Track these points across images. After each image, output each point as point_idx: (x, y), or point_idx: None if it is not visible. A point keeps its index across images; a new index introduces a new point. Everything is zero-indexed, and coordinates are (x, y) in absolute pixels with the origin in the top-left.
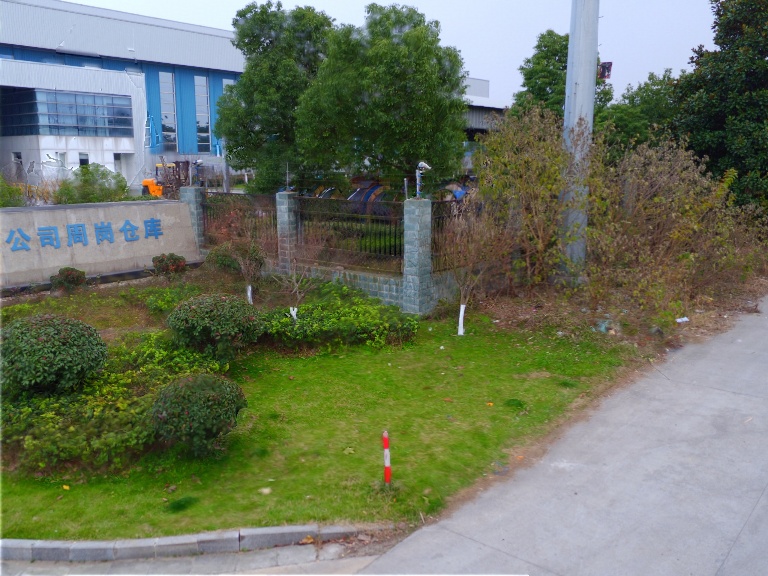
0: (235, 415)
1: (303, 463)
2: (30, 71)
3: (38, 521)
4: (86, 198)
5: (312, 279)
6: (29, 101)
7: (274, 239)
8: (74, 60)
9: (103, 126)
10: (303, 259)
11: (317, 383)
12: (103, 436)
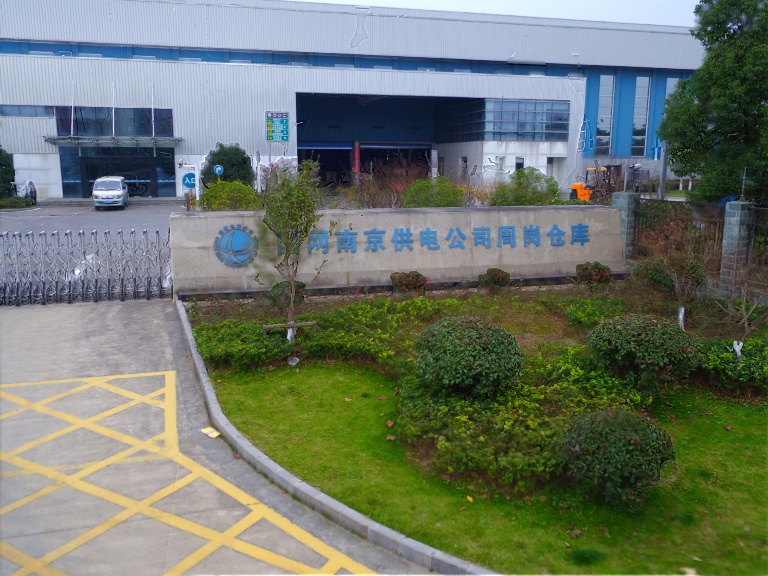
0: (659, 467)
1: (742, 549)
2: (483, 83)
3: (441, 529)
4: (519, 201)
5: (762, 307)
6: (479, 110)
7: (717, 255)
8: (522, 69)
9: (540, 131)
10: (752, 282)
11: (764, 442)
12: (511, 454)
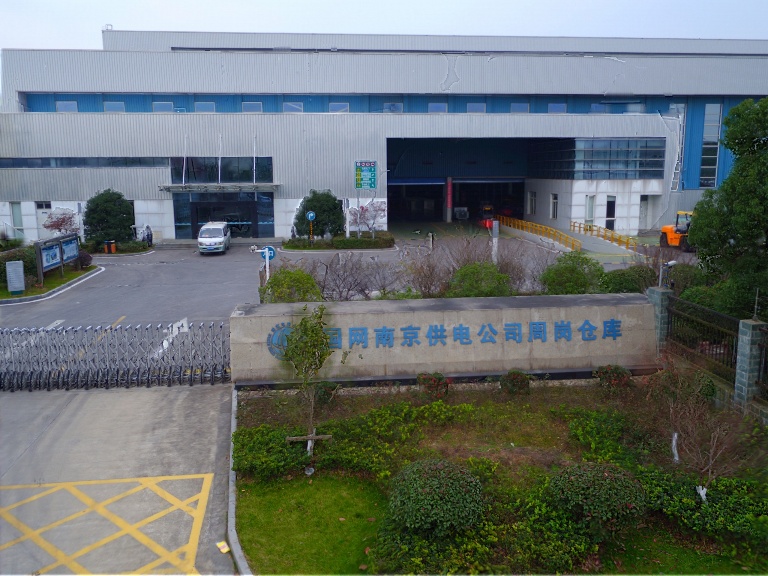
0: None
1: None
2: (573, 122)
3: None
4: (563, 286)
5: (767, 429)
6: (569, 149)
7: (733, 368)
8: (614, 108)
9: (634, 169)
10: (763, 401)
11: None
12: None
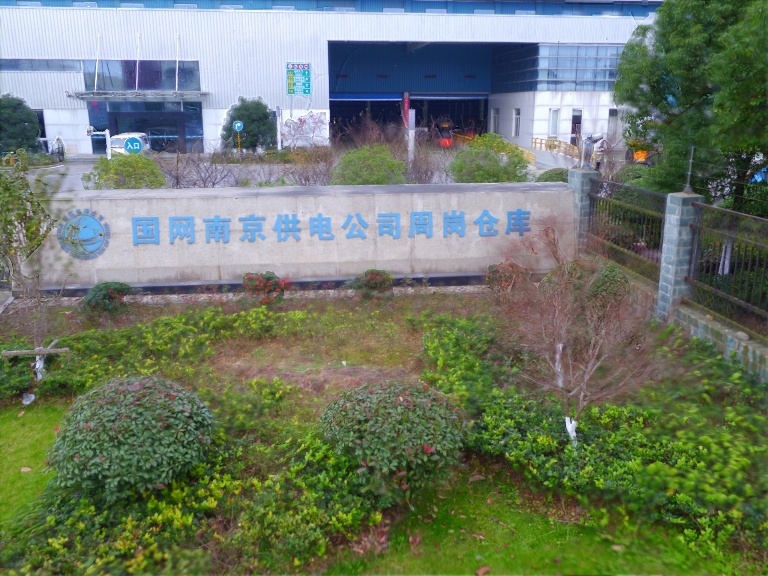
0: None
1: None
2: (537, 25)
3: None
4: (471, 175)
5: (695, 340)
6: (532, 56)
7: (659, 262)
8: (582, 9)
9: (602, 79)
10: (693, 303)
11: None
12: None
